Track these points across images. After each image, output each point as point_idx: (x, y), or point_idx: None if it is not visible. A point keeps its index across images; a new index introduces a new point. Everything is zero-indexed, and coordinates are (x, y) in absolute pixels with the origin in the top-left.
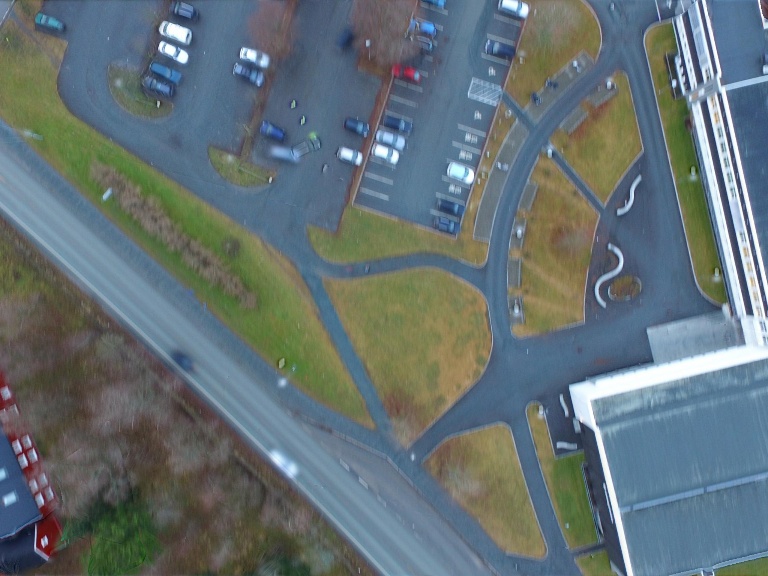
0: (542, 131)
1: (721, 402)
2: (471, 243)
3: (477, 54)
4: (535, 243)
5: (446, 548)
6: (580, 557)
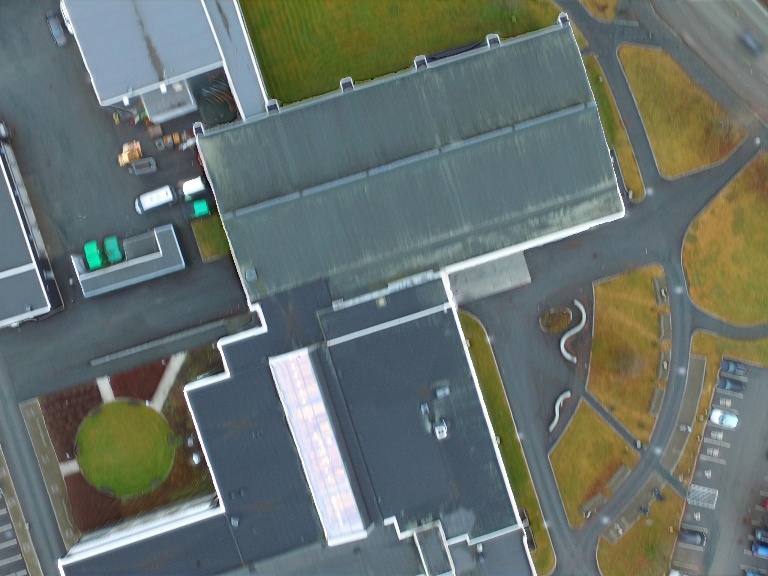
0: (648, 465)
1: (499, 218)
2: (709, 353)
3: (712, 531)
4: (649, 358)
5: (720, 51)
6: (583, 47)
